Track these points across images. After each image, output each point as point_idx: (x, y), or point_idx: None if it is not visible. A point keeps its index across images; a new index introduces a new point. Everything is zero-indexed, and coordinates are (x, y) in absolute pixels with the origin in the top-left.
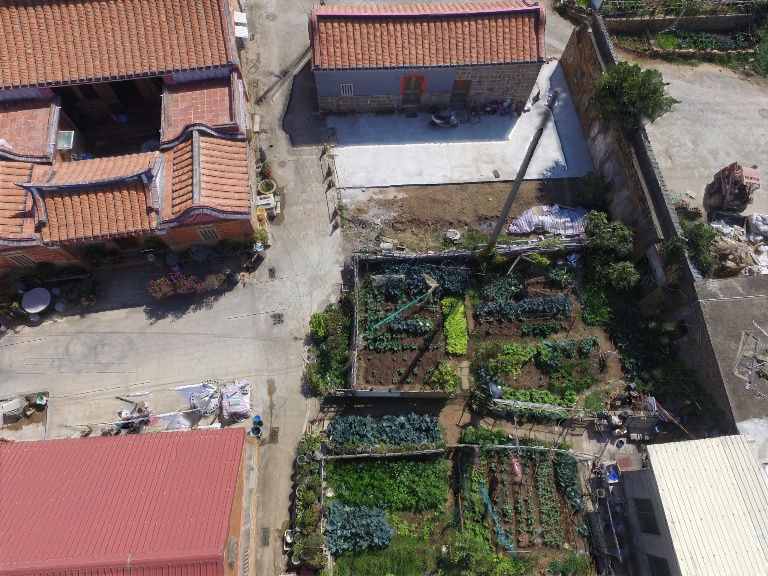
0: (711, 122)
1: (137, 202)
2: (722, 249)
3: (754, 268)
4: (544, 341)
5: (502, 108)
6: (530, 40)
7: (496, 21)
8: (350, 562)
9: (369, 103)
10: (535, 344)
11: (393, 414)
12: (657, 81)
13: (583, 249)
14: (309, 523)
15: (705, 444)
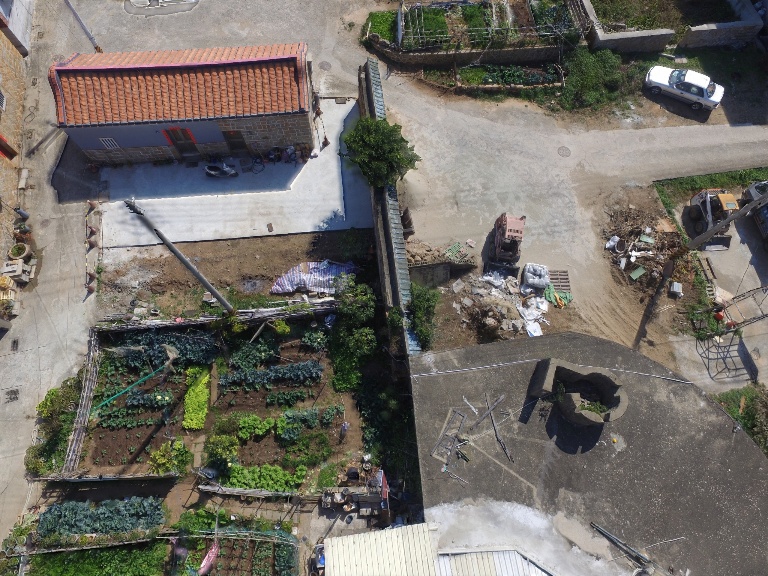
0: (506, 163)
1: None
2: (484, 305)
3: (517, 323)
4: (287, 411)
5: (286, 155)
6: (291, 90)
7: (254, 71)
8: None
9: (142, 154)
10: (278, 414)
11: (116, 497)
12: (396, 138)
13: (337, 311)
14: None
15: (384, 535)
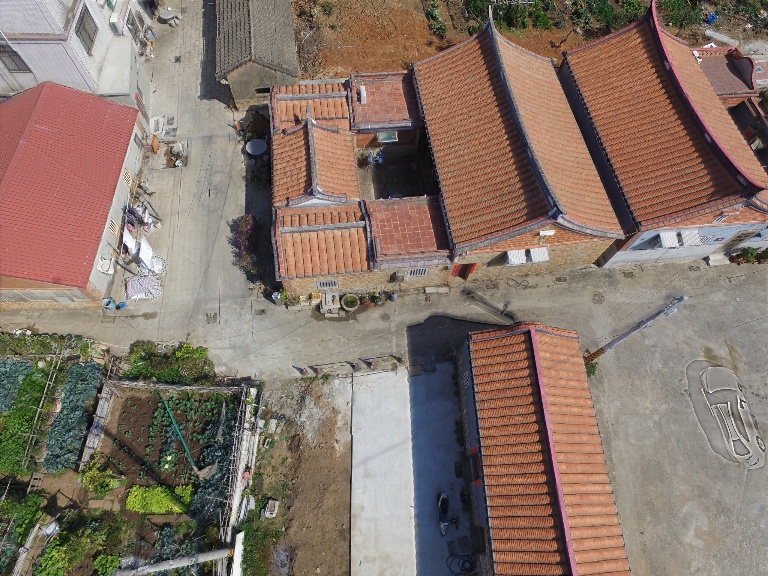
0: None
1: (297, 189)
2: None
3: None
4: None
5: None
6: None
7: None
8: None
9: None
10: None
11: (90, 423)
12: None
13: None
14: None
15: None
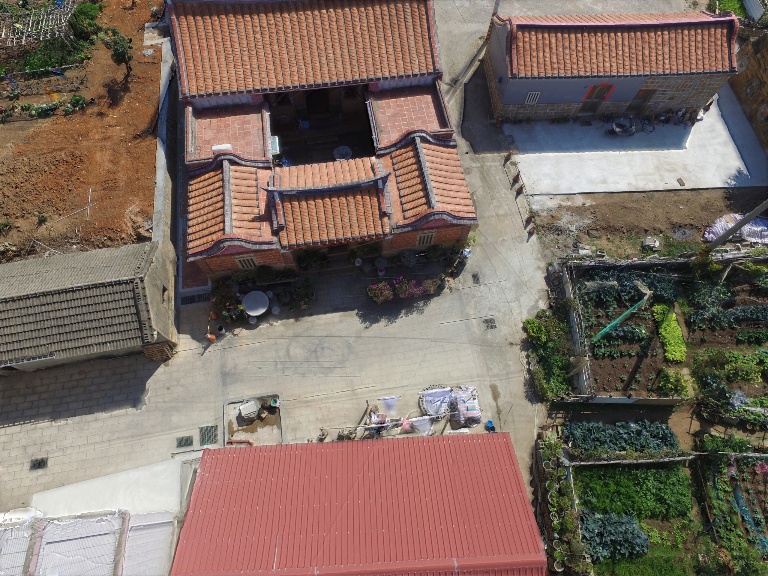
0: None
1: (370, 207)
2: None
3: None
4: (761, 349)
5: (677, 117)
6: (722, 50)
7: (689, 31)
8: (611, 570)
9: (547, 111)
10: (752, 352)
11: (623, 421)
12: None
13: None
14: (570, 530)
15: None
